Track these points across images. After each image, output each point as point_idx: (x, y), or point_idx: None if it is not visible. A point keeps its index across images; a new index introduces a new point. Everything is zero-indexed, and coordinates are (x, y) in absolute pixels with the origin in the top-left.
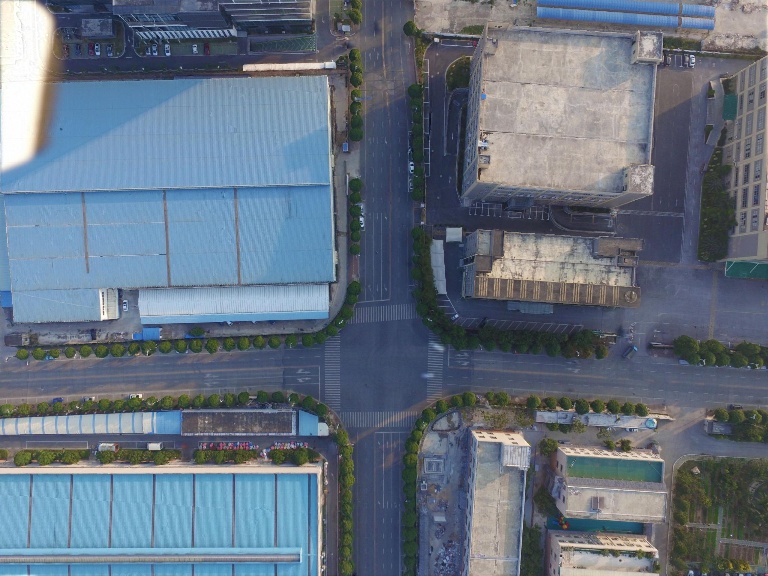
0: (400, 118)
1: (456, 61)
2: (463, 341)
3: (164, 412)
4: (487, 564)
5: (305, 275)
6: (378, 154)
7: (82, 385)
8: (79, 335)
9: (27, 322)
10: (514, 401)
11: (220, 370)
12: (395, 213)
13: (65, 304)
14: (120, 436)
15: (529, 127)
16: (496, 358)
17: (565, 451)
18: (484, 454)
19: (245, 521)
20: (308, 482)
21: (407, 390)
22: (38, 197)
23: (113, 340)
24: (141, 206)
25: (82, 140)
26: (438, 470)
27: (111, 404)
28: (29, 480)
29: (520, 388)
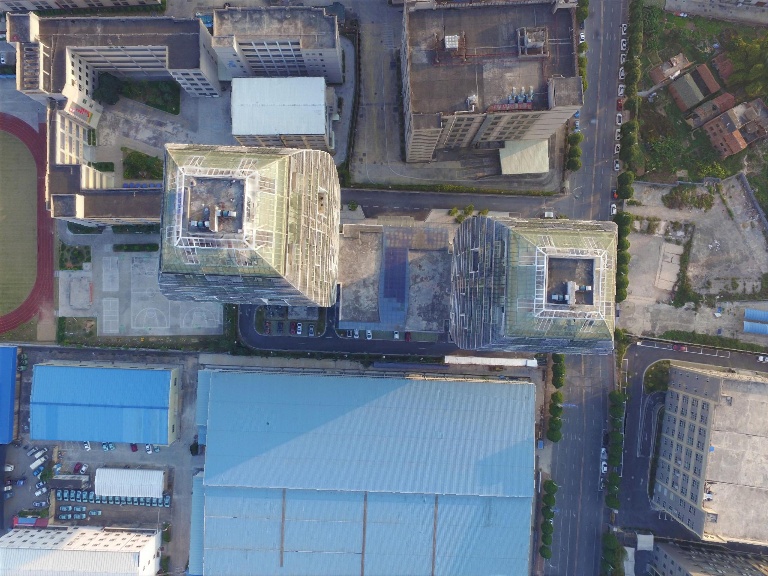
0: (595, 416)
1: (655, 363)
2: None
3: None
4: None
5: None
6: (571, 450)
7: None
8: None
9: None
10: None
11: None
12: (584, 511)
13: None
14: None
15: (753, 479)
16: None
17: None
18: None
19: None
20: None
21: None
22: (239, 489)
23: None
24: (341, 505)
25: (288, 436)
26: None
27: None
28: None
29: None
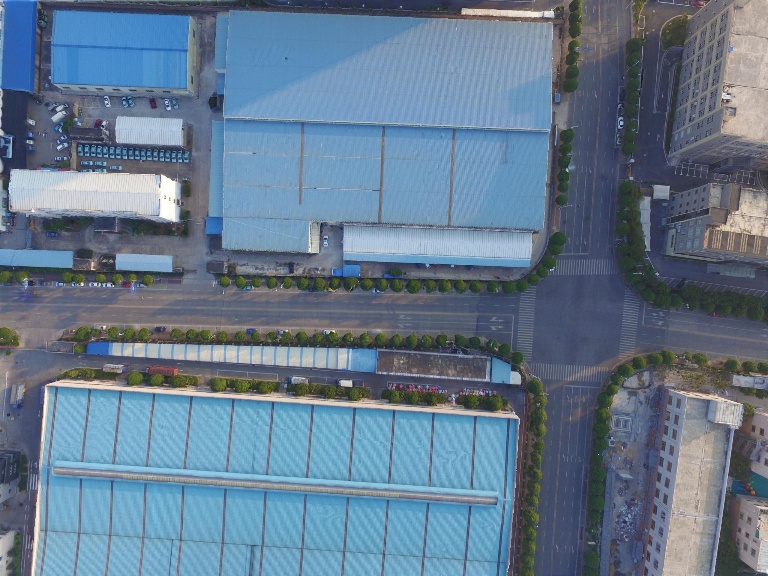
0: (612, 73)
1: (673, 19)
2: (668, 298)
3: (359, 349)
4: (686, 521)
5: (515, 221)
6: (587, 107)
7: (276, 317)
8: (276, 268)
9: (235, 249)
10: (707, 364)
11: (414, 312)
12: (600, 167)
13: (275, 233)
14: (310, 371)
15: None
16: (691, 320)
17: (766, 415)
18: (691, 411)
19: (442, 461)
20: (507, 427)
21: (600, 345)
22: (258, 125)
23: (310, 275)
24: (359, 141)
25: (306, 71)
26: (625, 427)
27: (307, 338)
28: (231, 405)
29: (713, 351)
